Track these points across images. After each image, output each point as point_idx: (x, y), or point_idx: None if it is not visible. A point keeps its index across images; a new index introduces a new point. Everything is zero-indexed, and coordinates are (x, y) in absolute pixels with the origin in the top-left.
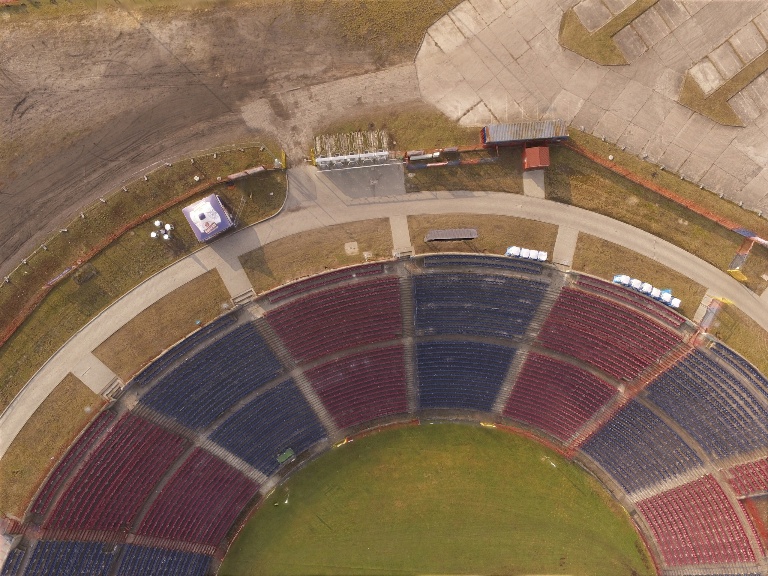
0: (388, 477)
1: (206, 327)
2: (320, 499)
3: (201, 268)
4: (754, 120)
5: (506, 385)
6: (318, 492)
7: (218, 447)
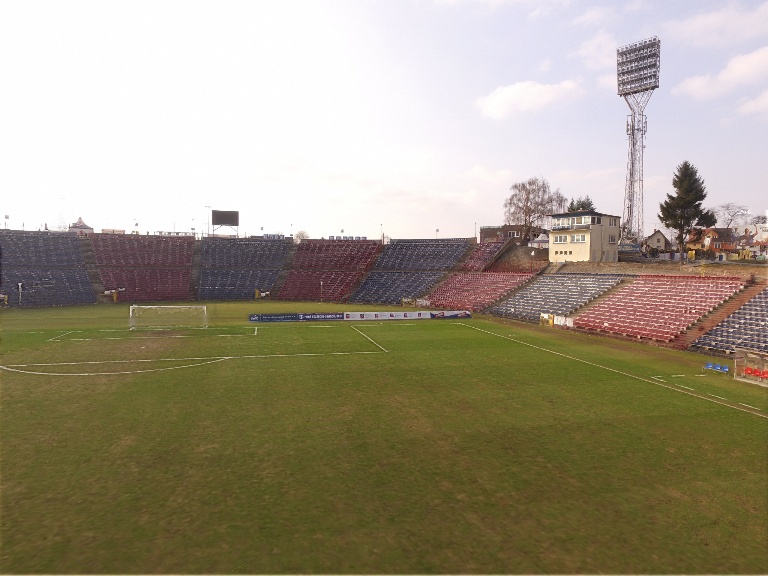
0: None
1: None
2: None
3: None
4: None
5: None
6: None
7: None
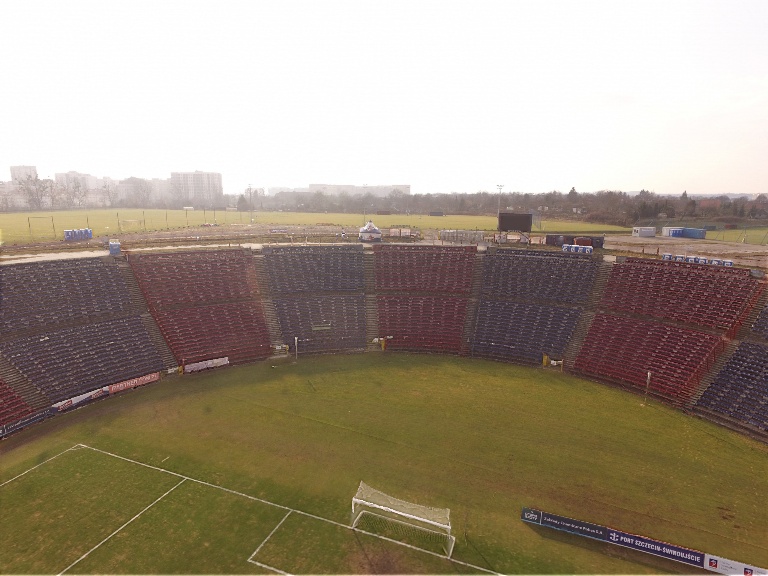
0: (413, 377)
1: (336, 247)
2: (323, 373)
3: (351, 243)
4: (766, 260)
5: (575, 342)
6: (325, 370)
7: (273, 311)
